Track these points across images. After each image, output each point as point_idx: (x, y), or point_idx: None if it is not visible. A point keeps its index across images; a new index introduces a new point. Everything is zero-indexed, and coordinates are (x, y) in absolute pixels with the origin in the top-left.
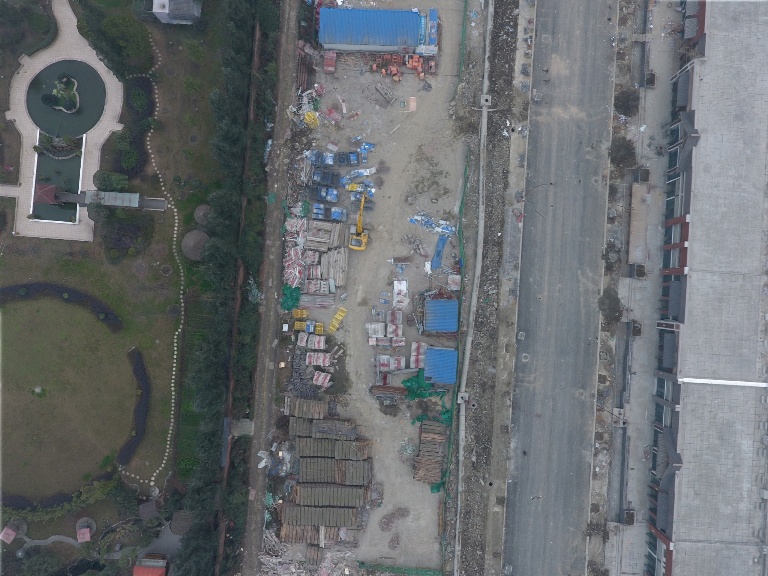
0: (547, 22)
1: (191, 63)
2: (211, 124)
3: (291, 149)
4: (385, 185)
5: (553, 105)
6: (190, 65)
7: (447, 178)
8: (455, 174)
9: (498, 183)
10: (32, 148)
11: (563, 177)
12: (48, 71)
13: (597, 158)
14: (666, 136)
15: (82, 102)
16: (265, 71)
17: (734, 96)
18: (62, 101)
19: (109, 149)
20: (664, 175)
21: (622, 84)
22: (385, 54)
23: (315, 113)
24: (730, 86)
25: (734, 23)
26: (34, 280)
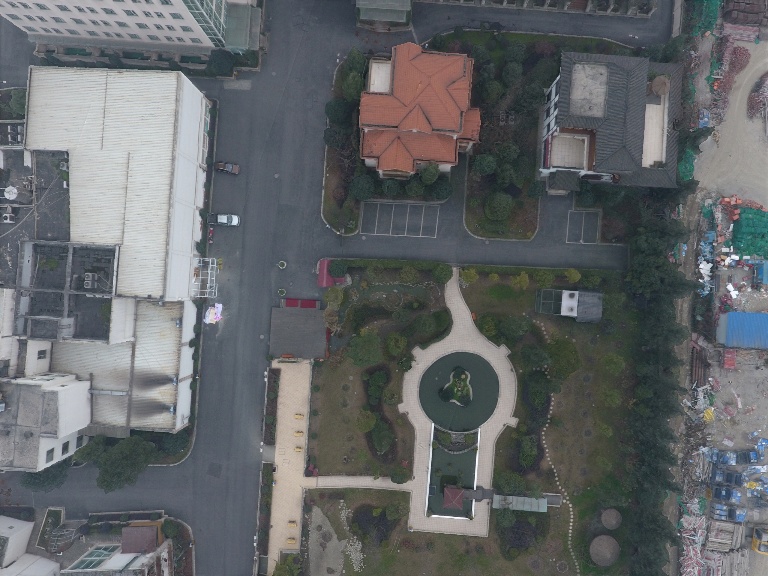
0: None
1: (585, 356)
2: (606, 418)
3: (685, 443)
4: None
5: None
6: (584, 358)
7: None
8: None
9: None
10: (425, 441)
11: None
12: (440, 363)
13: None
14: None
15: (474, 394)
16: (671, 373)
17: None
18: (456, 394)
19: (503, 443)
20: None
21: None
22: None
23: (711, 408)
24: None
25: None
26: (429, 575)
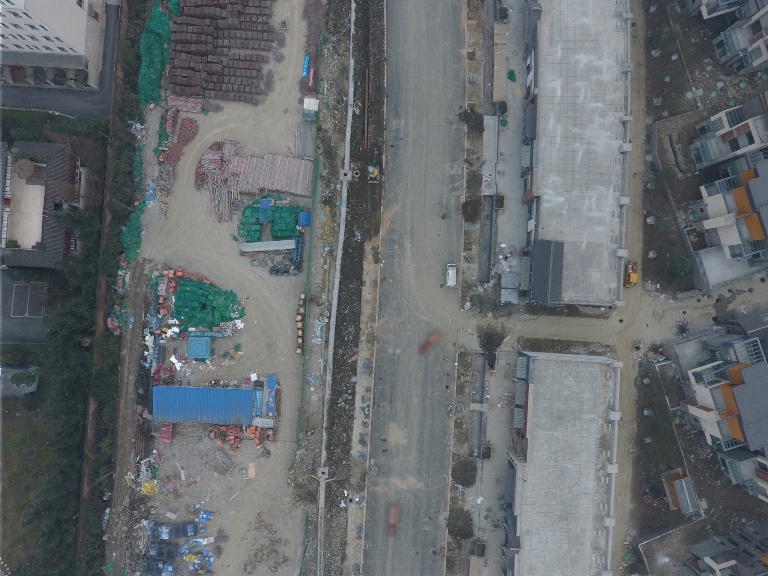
0: (385, 390)
1: None
2: None
3: (129, 516)
4: (224, 554)
5: (391, 475)
6: None
7: (286, 546)
8: (294, 542)
9: (336, 555)
10: None
11: (400, 549)
12: None
13: (435, 529)
14: (503, 508)
15: None
16: (98, 449)
17: (558, 496)
18: None
19: None
20: (500, 549)
21: (460, 453)
22: (222, 425)
23: (153, 481)
24: (554, 486)
25: (558, 422)
26: None
